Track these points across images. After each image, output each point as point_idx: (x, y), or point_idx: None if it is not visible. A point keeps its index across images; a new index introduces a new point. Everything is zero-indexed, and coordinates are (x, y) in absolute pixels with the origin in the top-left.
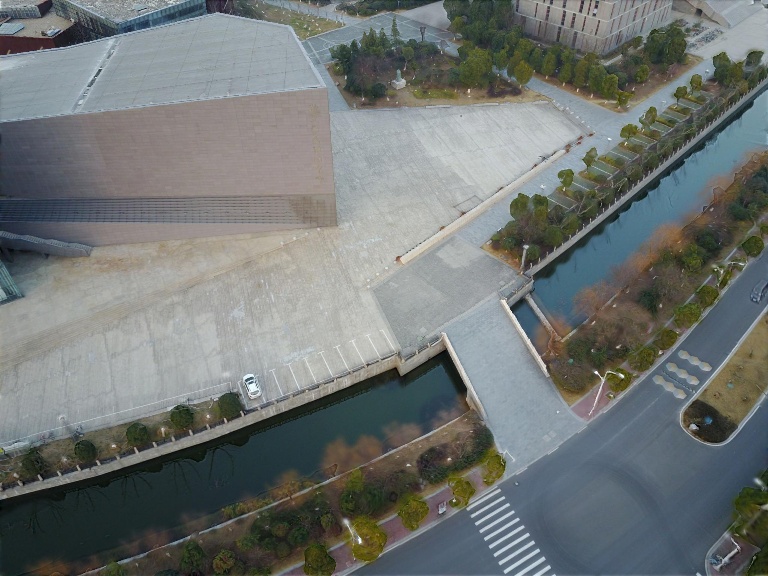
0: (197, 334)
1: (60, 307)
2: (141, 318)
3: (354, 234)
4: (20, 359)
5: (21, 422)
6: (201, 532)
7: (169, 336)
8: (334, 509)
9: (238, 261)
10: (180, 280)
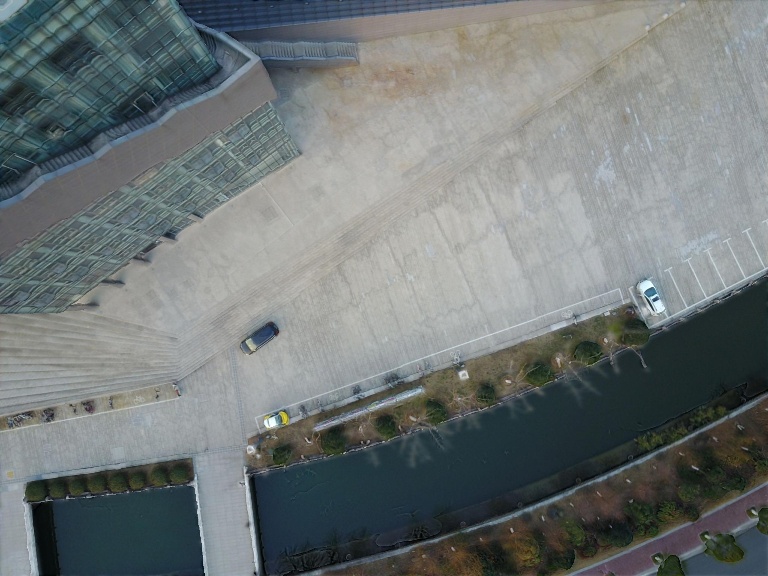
0: (558, 212)
1: (361, 172)
2: (473, 183)
3: (755, 2)
4: (340, 258)
5: (383, 348)
6: (623, 468)
7: (521, 215)
8: (764, 450)
9: (587, 70)
10: (512, 114)
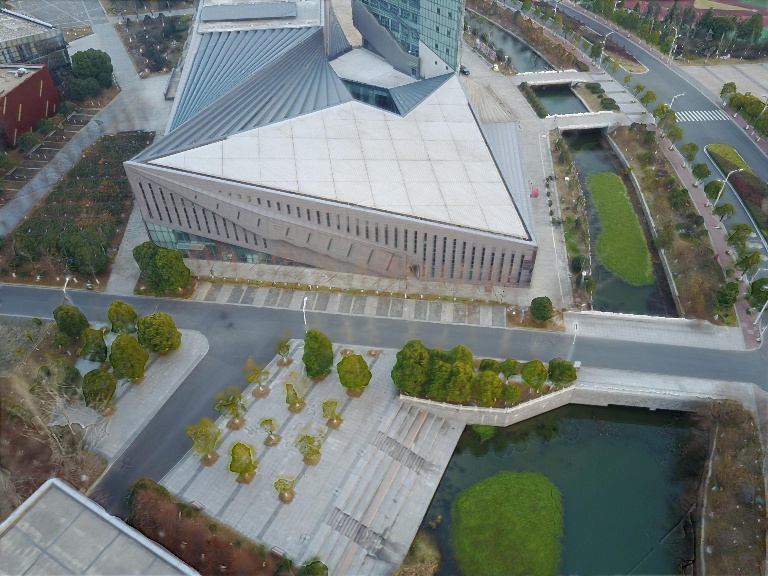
0: None
1: None
2: None
3: None
4: None
5: None
6: None
7: None
8: None
9: None
10: None
